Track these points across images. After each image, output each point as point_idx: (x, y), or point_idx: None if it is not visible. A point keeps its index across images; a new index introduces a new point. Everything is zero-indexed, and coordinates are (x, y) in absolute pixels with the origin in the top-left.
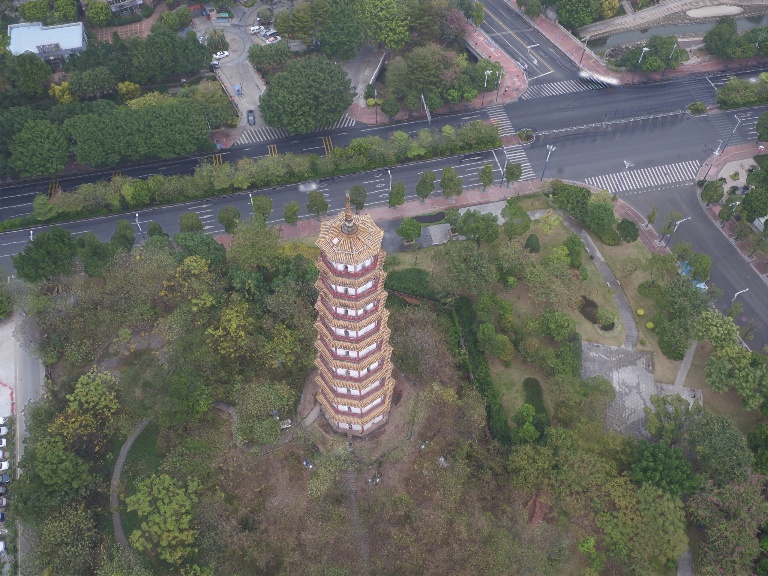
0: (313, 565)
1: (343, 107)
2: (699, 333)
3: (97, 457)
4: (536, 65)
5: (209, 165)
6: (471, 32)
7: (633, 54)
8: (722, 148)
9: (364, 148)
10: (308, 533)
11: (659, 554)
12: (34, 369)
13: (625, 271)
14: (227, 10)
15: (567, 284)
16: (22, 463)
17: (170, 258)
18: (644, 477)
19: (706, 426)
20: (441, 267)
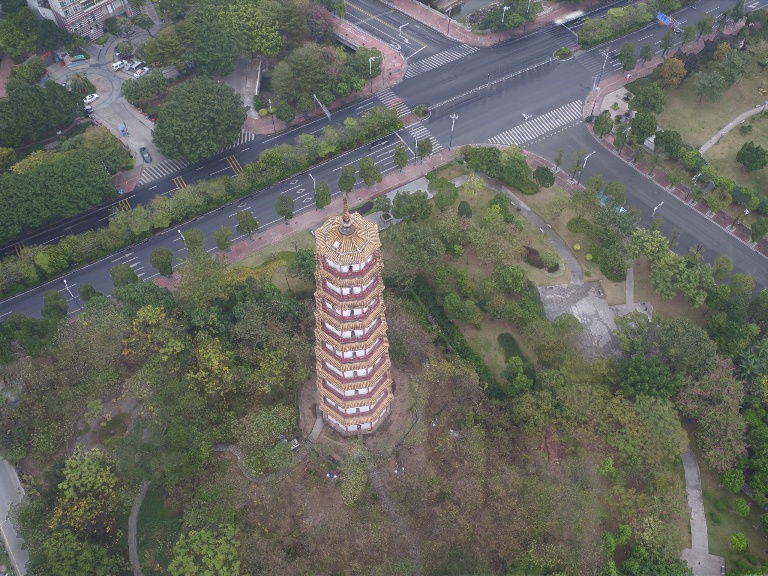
0: (377, 567)
1: (239, 123)
2: (636, 252)
3: (106, 539)
4: (408, 44)
5: (122, 212)
6: (337, 25)
7: (494, 15)
8: (596, 84)
9: (275, 158)
10: (362, 538)
11: (668, 454)
12: (1, 472)
13: (553, 214)
14: (81, 51)
15: (509, 239)
16: (31, 570)
17: (120, 315)
18: (635, 391)
19: (671, 330)
20: (392, 253)
